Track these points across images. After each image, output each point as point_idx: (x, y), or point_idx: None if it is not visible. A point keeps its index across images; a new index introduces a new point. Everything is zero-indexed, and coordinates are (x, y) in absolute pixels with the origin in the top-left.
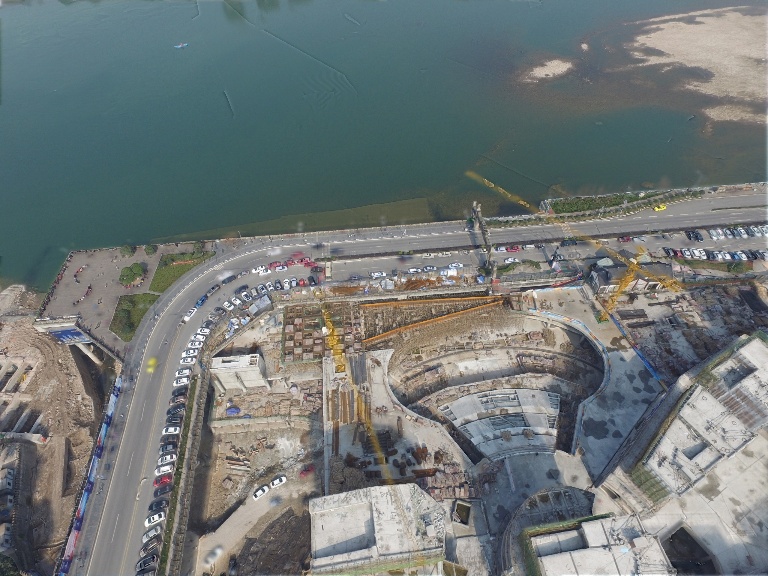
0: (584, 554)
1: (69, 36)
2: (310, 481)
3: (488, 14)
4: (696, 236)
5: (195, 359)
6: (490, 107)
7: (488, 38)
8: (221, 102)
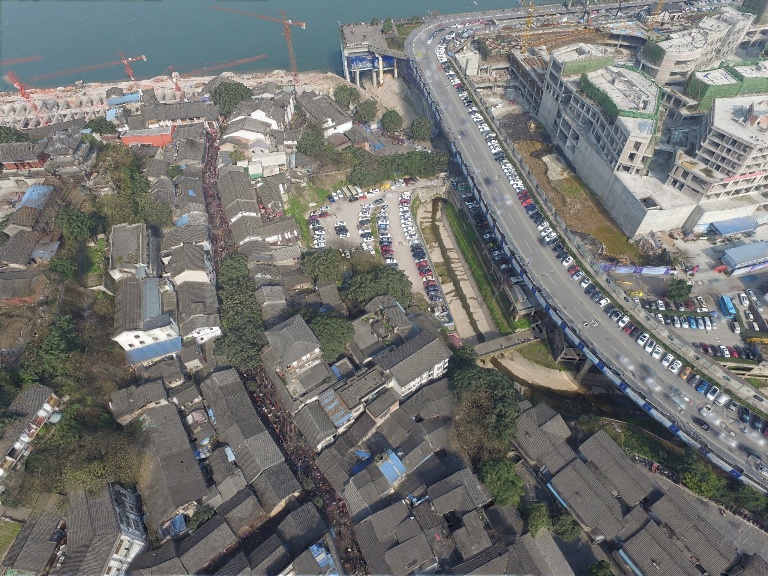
0: (673, 40)
1: None
2: (515, 105)
3: None
4: (690, 3)
5: (445, 54)
6: None
7: None
8: None
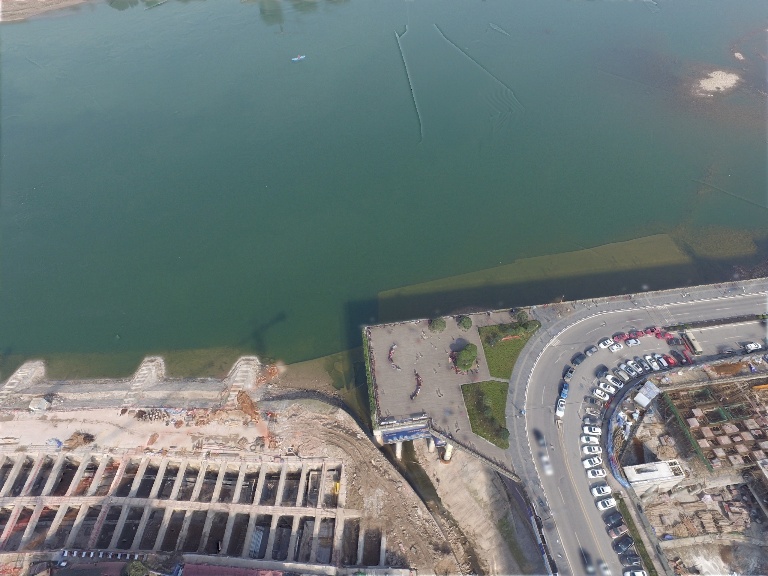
0: None
1: (162, 48)
2: None
3: (615, 20)
4: None
5: (605, 470)
6: (677, 125)
7: (631, 47)
8: (370, 123)
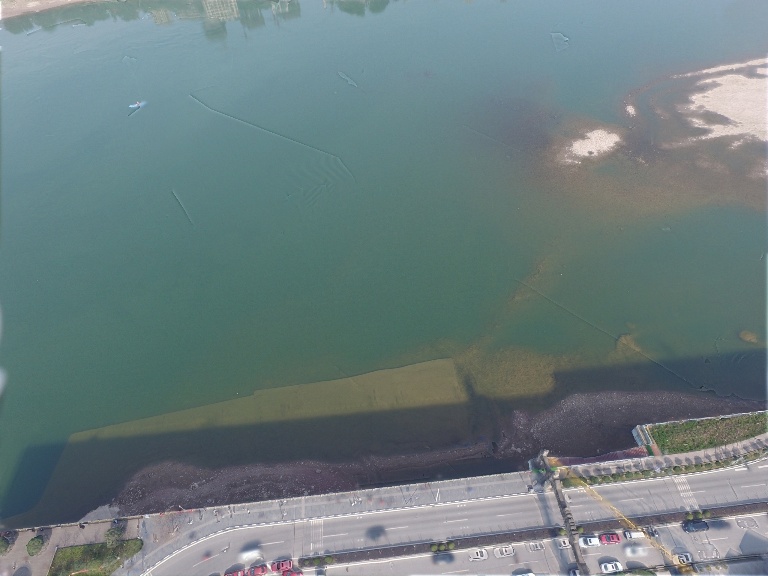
0: None
1: (4, 87)
2: None
3: (508, 61)
4: None
5: None
6: (524, 202)
7: (512, 96)
8: None
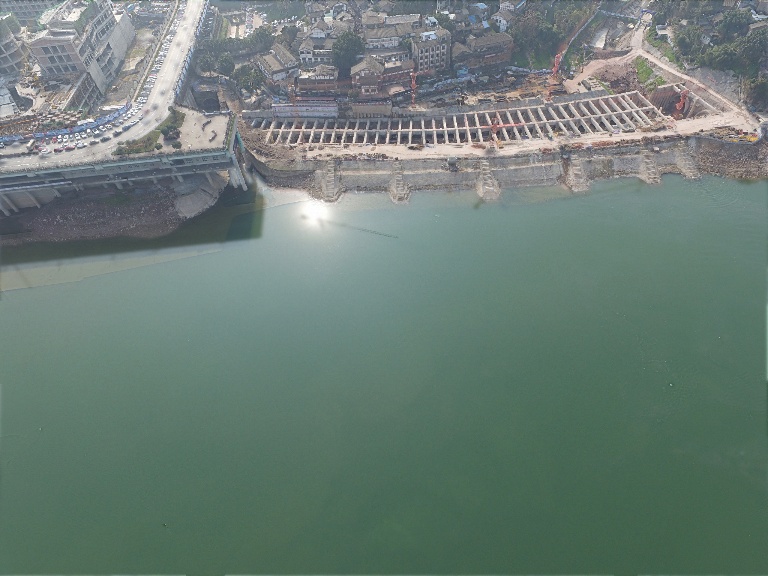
0: None
1: None
2: None
3: None
4: None
5: None
6: None
7: None
8: None
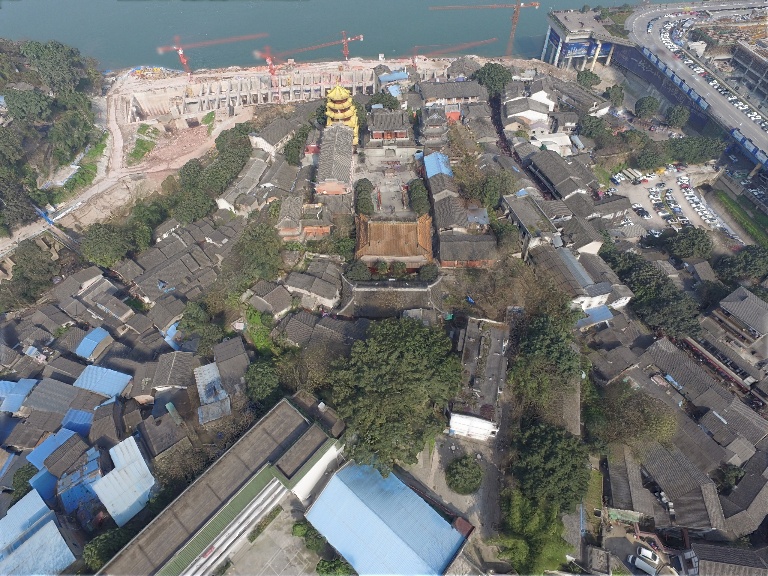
0: None
1: None
2: None
3: None
4: None
5: None
6: None
7: None
8: None
